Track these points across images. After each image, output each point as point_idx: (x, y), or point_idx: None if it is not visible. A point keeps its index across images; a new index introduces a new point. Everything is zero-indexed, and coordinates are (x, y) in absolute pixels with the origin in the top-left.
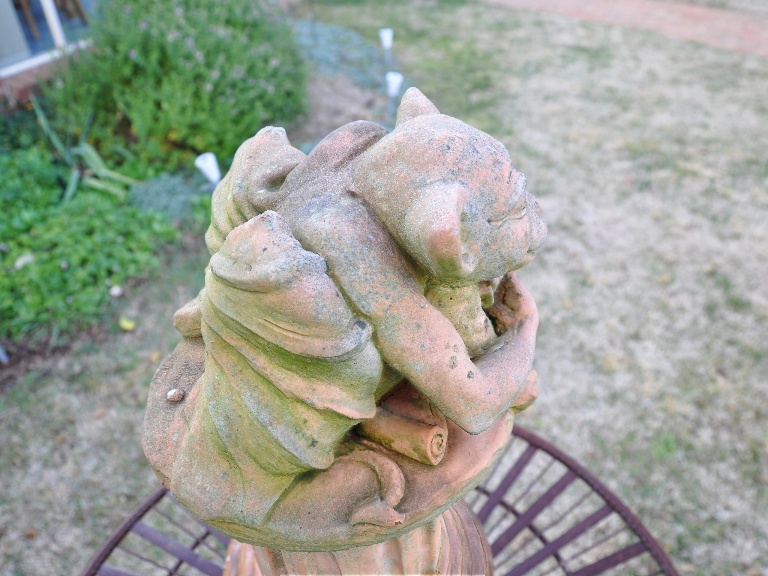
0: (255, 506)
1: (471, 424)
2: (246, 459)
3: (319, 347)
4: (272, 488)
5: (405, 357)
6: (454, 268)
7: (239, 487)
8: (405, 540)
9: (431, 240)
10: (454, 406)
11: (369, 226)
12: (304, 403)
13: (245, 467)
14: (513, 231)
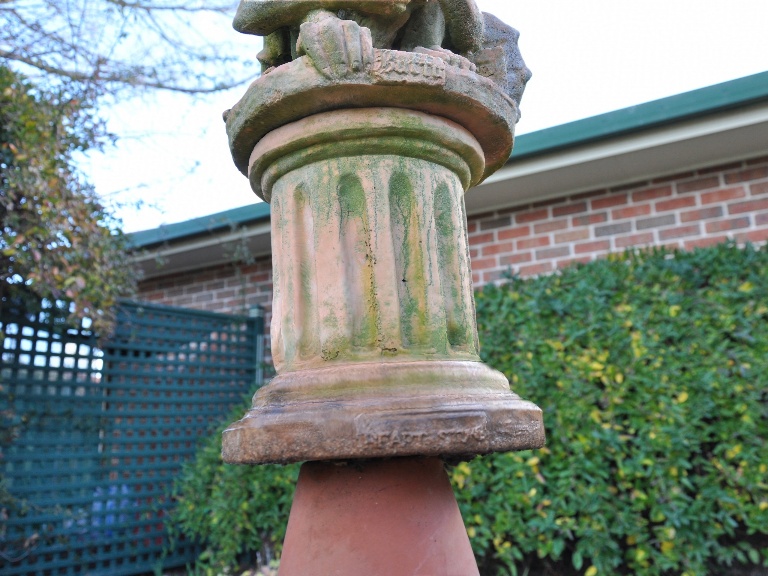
0: None
1: None
2: None
3: None
4: None
5: None
6: None
7: None
8: None
9: None
10: None
11: None
12: None
13: None
14: None
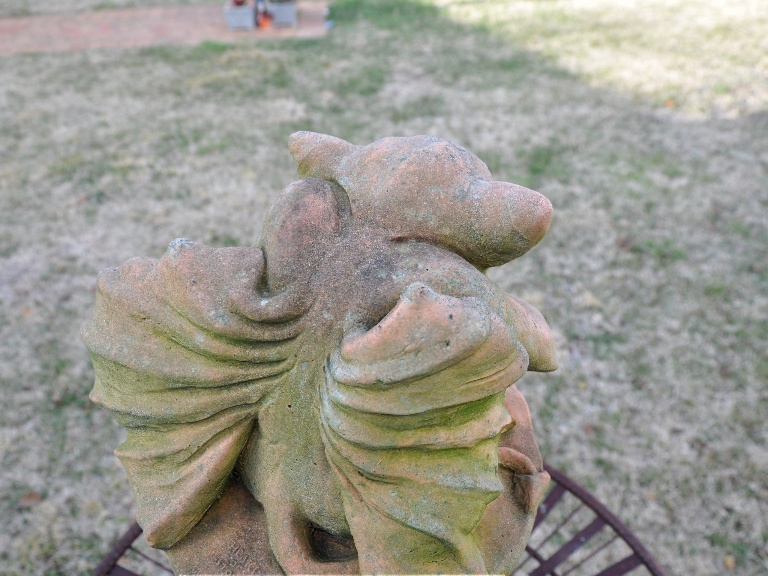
0: (482, 570)
1: (555, 362)
2: (459, 538)
3: (518, 369)
4: (473, 546)
5: (525, 340)
6: None
7: (457, 572)
8: None
9: (539, 226)
10: (546, 356)
11: (448, 254)
12: (483, 441)
13: (461, 546)
14: None
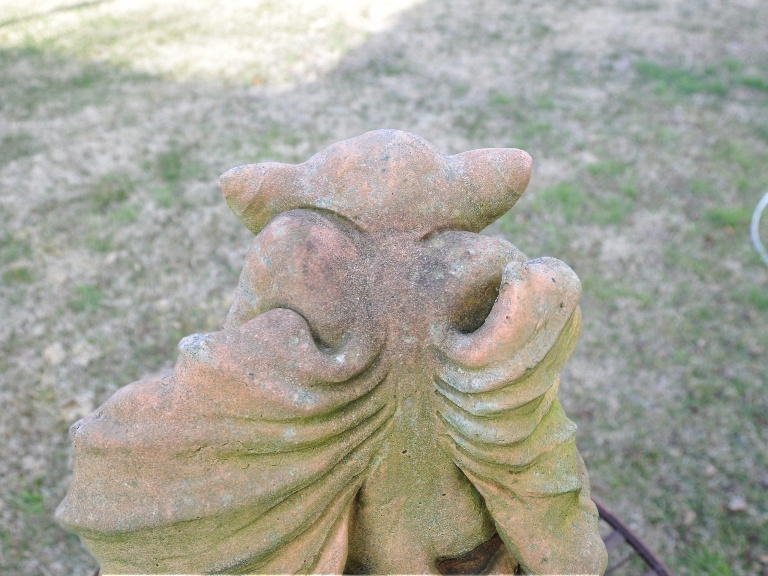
0: None
1: None
2: None
3: None
4: None
5: None
6: None
7: (579, 514)
8: None
9: None
10: None
11: None
12: None
13: None
14: None
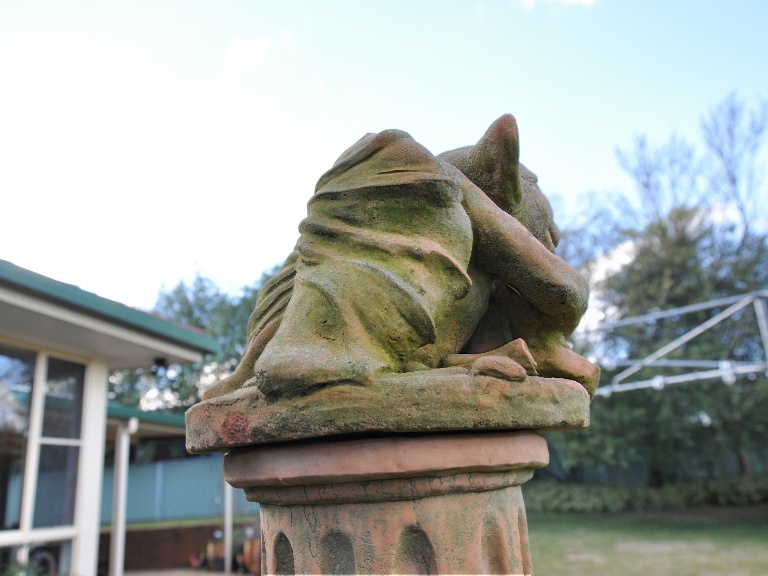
0: (364, 356)
1: (561, 278)
2: (352, 314)
3: None
4: (377, 355)
5: (492, 217)
6: (515, 155)
7: (341, 351)
8: (512, 566)
9: (498, 126)
10: (542, 262)
11: None
12: (409, 257)
13: (351, 322)
14: None
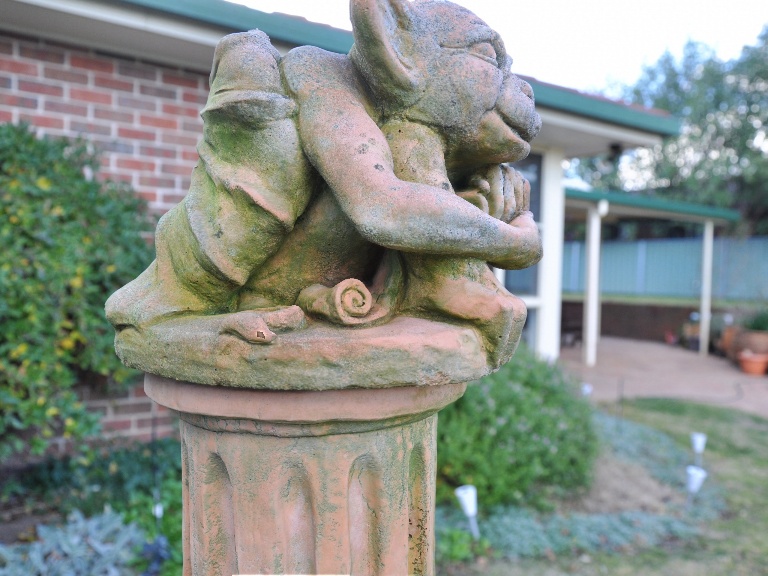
0: (150, 302)
1: (363, 214)
2: (166, 256)
3: (236, 94)
4: (176, 299)
5: (316, 133)
6: (371, 34)
7: None
8: (322, 510)
9: None
10: (351, 192)
11: None
12: (226, 191)
13: (162, 264)
14: (468, 62)
